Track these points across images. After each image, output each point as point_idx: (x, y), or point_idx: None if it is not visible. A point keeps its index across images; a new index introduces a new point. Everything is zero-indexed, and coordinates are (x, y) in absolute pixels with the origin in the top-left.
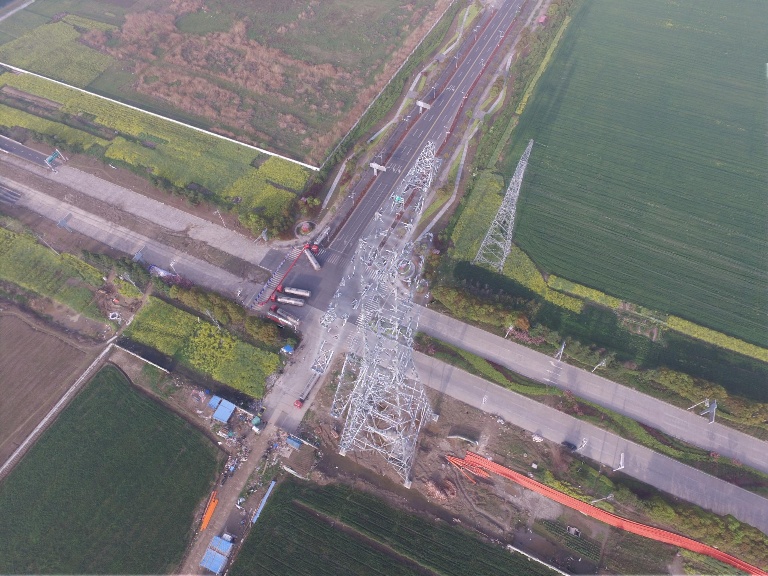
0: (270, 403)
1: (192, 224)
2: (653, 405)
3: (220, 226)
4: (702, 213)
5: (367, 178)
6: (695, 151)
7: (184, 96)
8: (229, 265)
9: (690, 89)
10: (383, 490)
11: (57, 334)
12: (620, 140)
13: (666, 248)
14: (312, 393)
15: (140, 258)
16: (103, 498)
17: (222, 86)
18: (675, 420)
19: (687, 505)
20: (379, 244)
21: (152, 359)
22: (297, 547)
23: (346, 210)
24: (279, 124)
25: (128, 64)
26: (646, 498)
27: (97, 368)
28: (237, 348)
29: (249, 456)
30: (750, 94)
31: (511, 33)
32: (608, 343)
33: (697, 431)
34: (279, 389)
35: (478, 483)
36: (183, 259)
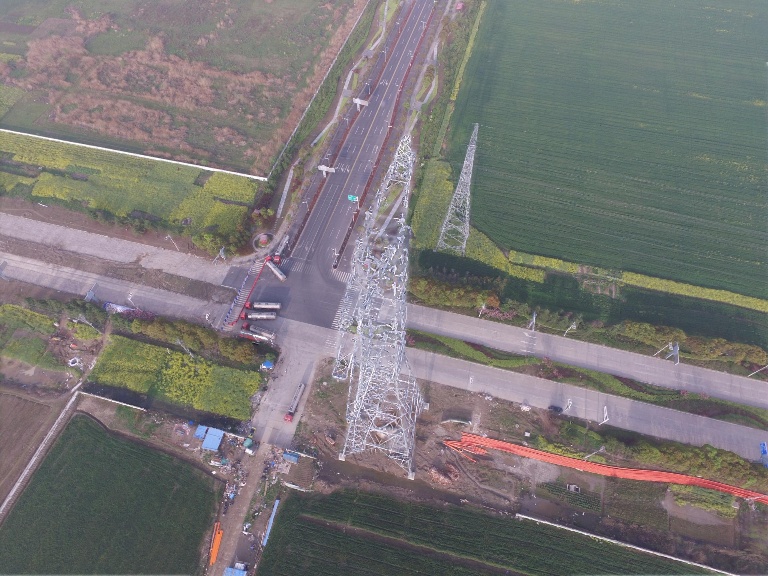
0: (259, 422)
1: (142, 253)
2: (623, 357)
3: (173, 251)
4: (635, 173)
5: (317, 181)
6: (619, 116)
7: (109, 121)
8: (190, 290)
9: (605, 59)
10: (388, 486)
11: (13, 392)
12: (551, 114)
13: (610, 210)
14: (300, 404)
15: (92, 297)
16: (98, 554)
17: (148, 106)
18: (645, 367)
19: (669, 443)
20: (341, 245)
21: (125, 400)
22: (313, 560)
23: (301, 216)
24: (217, 138)
25: (40, 94)
26: (632, 444)
27: (65, 420)
28: (214, 373)
29: (247, 480)
30: (658, 58)
31: (432, 22)
32: (574, 306)
33: (665, 374)
34: (266, 406)
35: (478, 461)
36: (139, 291)
